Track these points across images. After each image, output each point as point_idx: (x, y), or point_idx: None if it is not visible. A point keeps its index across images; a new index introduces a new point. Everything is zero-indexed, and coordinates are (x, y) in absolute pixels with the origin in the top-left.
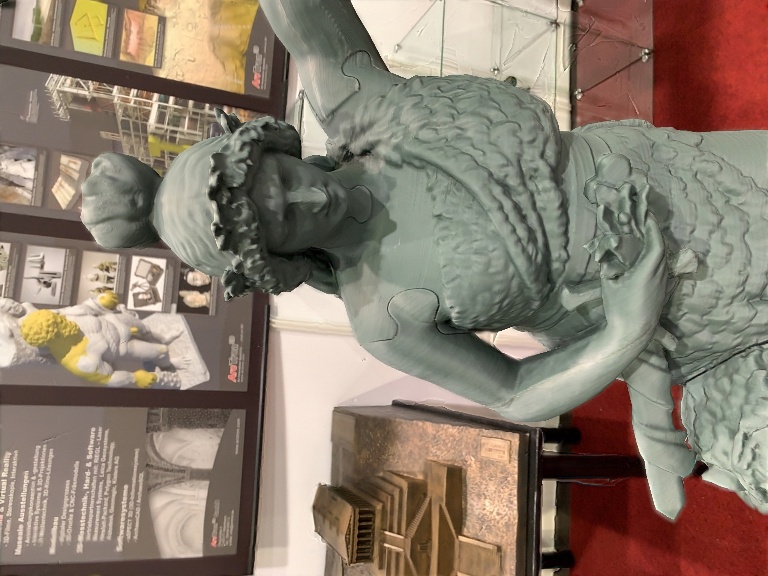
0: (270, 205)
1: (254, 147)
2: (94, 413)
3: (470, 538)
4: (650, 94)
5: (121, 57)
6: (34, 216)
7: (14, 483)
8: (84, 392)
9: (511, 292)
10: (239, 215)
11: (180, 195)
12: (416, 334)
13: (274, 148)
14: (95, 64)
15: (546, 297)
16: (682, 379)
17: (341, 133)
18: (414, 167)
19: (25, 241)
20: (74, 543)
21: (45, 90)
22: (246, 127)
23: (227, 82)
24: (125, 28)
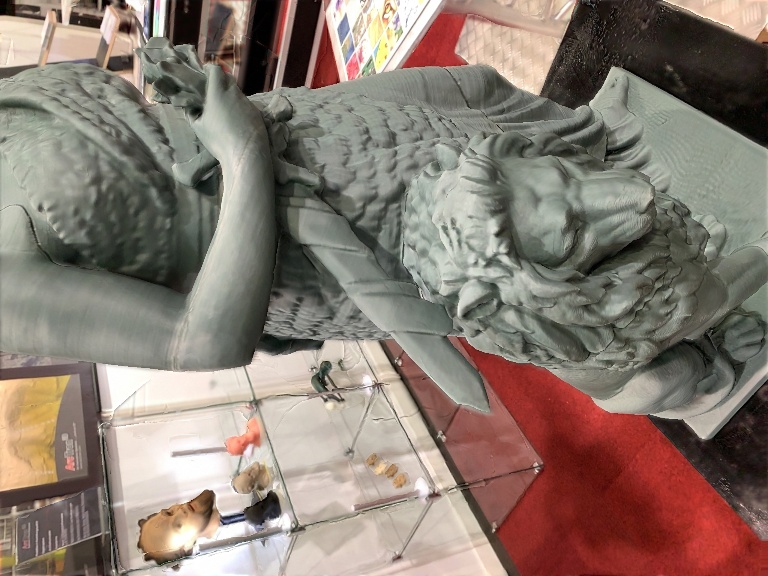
0: None
1: None
2: None
3: None
4: None
5: None
6: None
7: None
8: None
9: (103, 171)
10: None
11: None
12: (19, 266)
13: None
14: None
15: (168, 192)
16: (400, 267)
17: None
18: None
19: None
20: None
21: None
22: None
23: (36, 477)
24: None
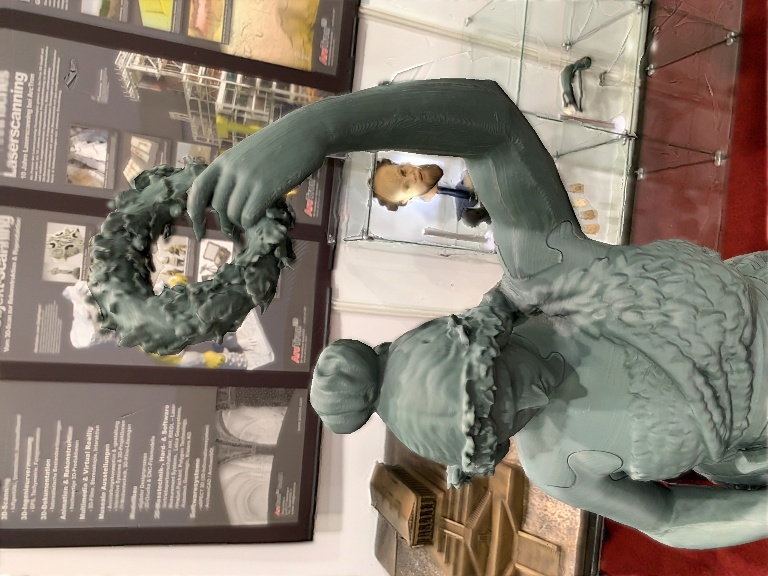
0: (505, 419)
1: (494, 366)
2: (167, 391)
3: (530, 534)
4: (732, 82)
5: (189, 33)
6: (107, 199)
7: (97, 455)
8: (158, 371)
9: (695, 463)
10: (485, 440)
11: (422, 408)
12: (592, 484)
13: None
14: (163, 40)
15: None
16: None
17: (533, 292)
18: (612, 342)
19: (99, 224)
20: (152, 510)
21: (115, 69)
22: (487, 346)
23: (294, 58)
24: (193, 1)
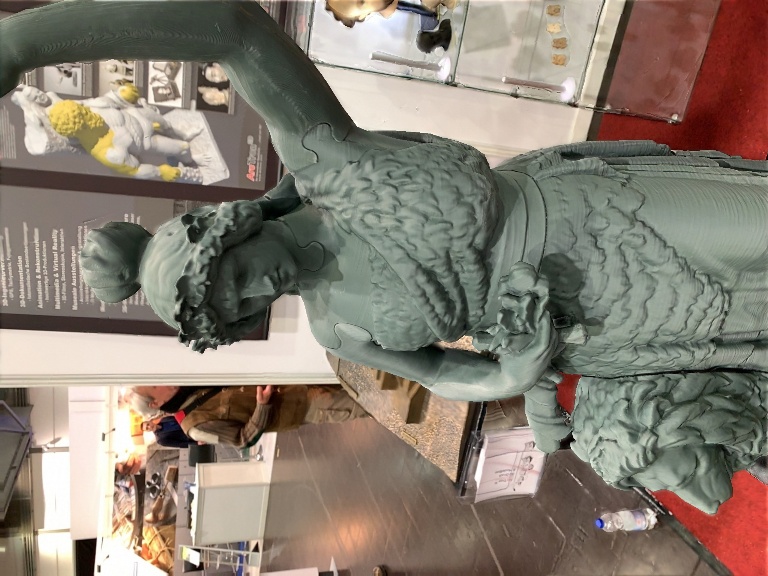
0: (227, 305)
1: (213, 264)
2: (126, 201)
3: None
4: None
5: None
6: None
7: (64, 255)
8: (115, 181)
9: (428, 342)
10: (200, 323)
11: (156, 293)
12: (355, 348)
13: (233, 245)
14: None
15: None
16: None
17: None
18: None
19: None
20: (119, 305)
21: None
22: (206, 247)
23: None
24: None
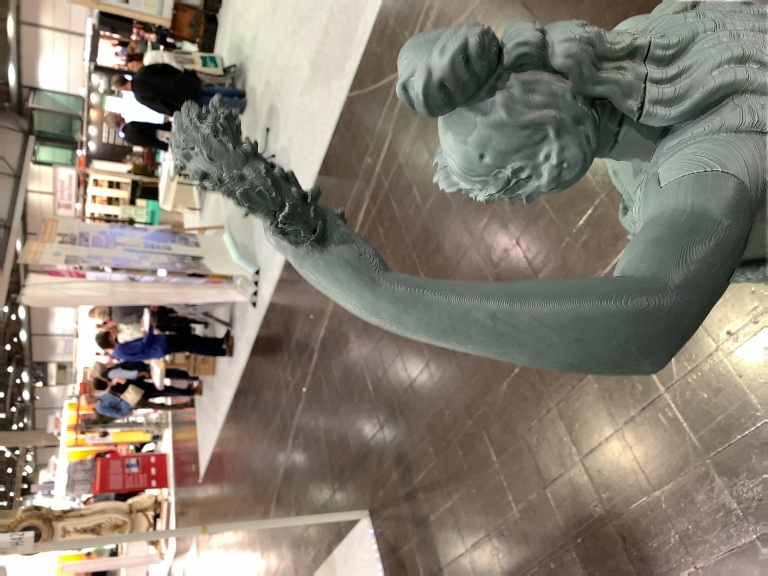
0: None
1: None
2: None
3: None
4: None
5: None
6: None
7: None
8: None
9: None
10: None
11: None
12: None
13: None
14: None
15: None
16: None
17: None
18: None
19: None
20: None
21: None
22: None
23: None
24: None
